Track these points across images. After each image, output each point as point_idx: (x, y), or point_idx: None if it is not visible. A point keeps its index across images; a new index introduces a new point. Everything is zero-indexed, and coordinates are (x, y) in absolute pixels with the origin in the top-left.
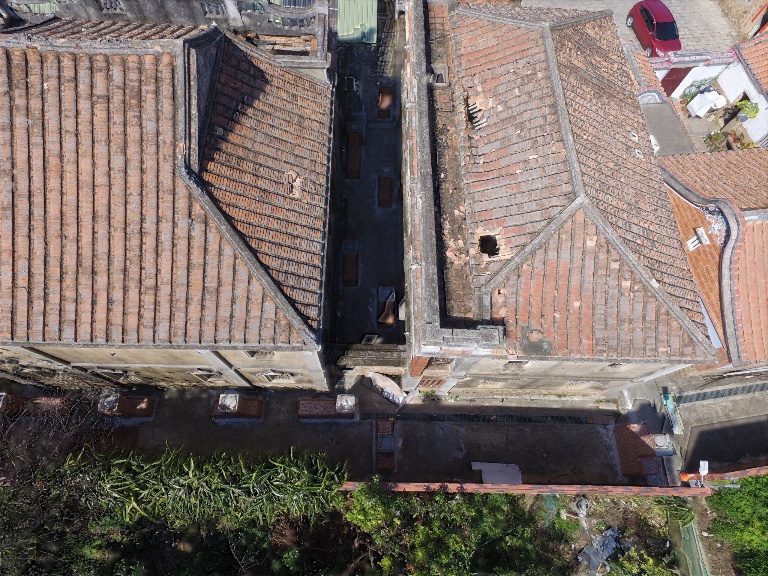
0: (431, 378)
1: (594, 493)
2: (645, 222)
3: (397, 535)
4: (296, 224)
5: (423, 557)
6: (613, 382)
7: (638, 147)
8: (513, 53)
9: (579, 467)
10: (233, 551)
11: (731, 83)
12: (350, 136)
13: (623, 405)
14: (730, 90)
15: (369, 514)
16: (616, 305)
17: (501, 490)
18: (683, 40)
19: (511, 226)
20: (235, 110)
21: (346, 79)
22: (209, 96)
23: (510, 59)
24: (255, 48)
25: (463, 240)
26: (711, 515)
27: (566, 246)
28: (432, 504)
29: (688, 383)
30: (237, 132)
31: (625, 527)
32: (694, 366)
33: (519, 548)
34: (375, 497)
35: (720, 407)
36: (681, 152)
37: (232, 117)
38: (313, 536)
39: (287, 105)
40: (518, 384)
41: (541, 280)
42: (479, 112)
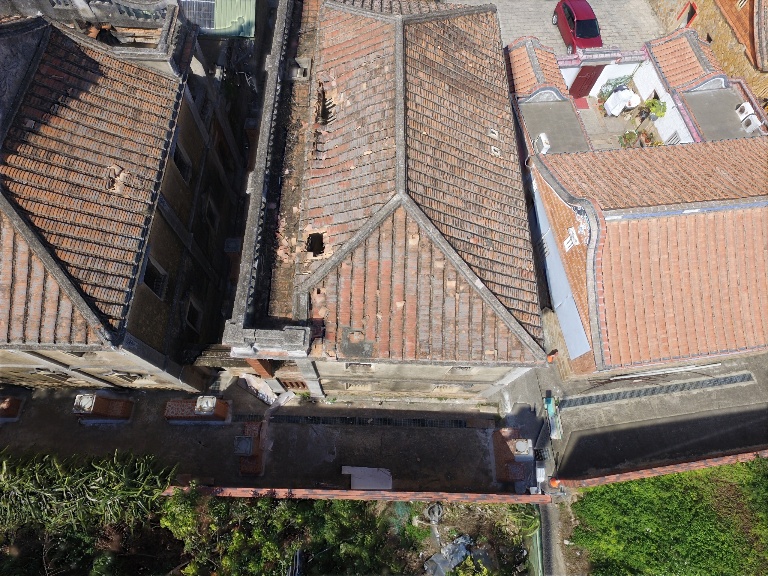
0: (289, 380)
1: (428, 500)
2: (485, 221)
3: (212, 542)
4: (111, 220)
5: (231, 565)
6: (478, 385)
7: (496, 144)
8: (367, 47)
9: (453, 472)
10: (44, 557)
11: (644, 81)
12: (248, 133)
13: (502, 409)
14: (643, 89)
15: (179, 520)
16: (441, 306)
17: (331, 496)
18: (609, 38)
19: (337, 224)
20: (55, 102)
21: (237, 74)
22: (21, 87)
23: (363, 53)
24: (89, 39)
25: (297, 238)
26: (574, 523)
27: (387, 245)
28: (252, 510)
29: (573, 387)
30: (53, 125)
31: (477, 535)
32: (573, 369)
33: (356, 556)
34: (185, 503)
35: (604, 412)
36: (576, 151)
37: (49, 109)
38: (141, 542)
39: (122, 98)
40: (385, 387)
41: (362, 280)
42: (333, 107)
